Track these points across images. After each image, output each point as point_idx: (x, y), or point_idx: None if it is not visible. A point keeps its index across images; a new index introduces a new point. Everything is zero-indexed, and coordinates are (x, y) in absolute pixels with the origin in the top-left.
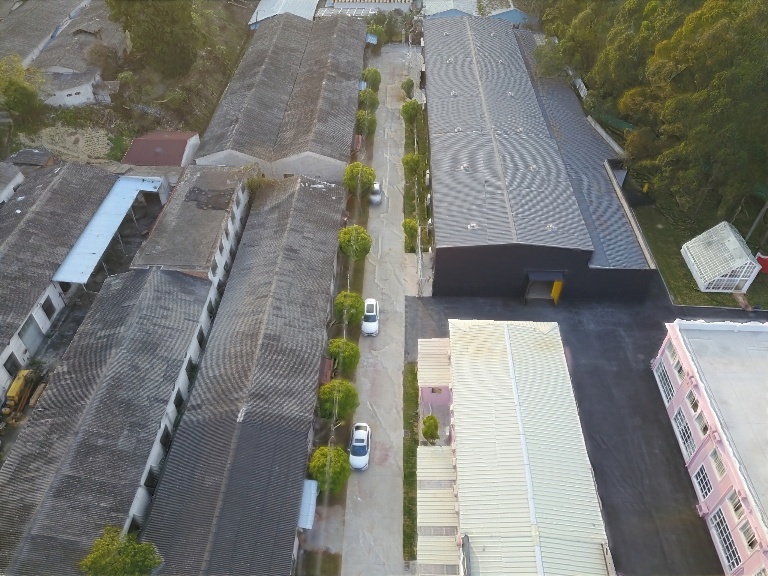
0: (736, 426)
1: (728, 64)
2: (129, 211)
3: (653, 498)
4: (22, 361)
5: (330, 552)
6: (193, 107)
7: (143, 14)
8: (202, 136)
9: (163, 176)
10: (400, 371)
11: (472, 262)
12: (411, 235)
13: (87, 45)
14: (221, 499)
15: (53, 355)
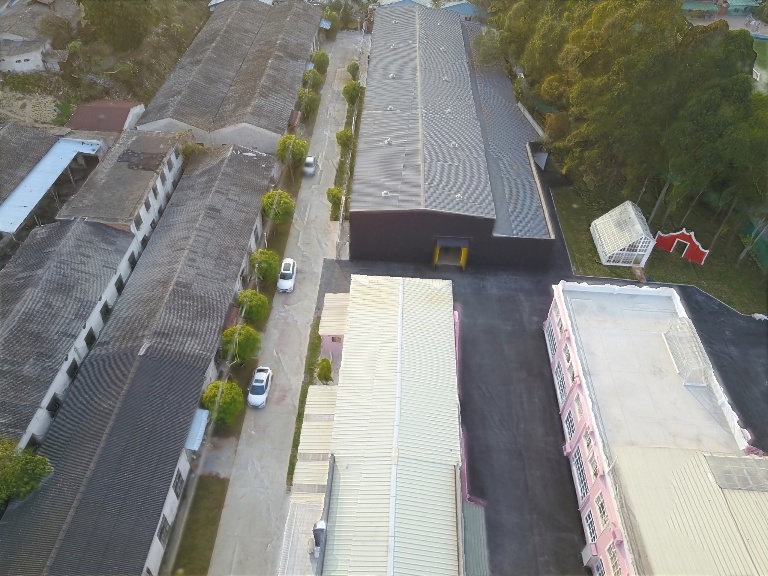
0: (598, 373)
1: (628, 51)
2: (66, 171)
3: (525, 439)
4: None
5: (219, 476)
6: (143, 80)
7: None
8: None
9: (102, 140)
10: (309, 324)
11: (384, 227)
12: (334, 203)
13: (40, 15)
14: (113, 419)
15: None
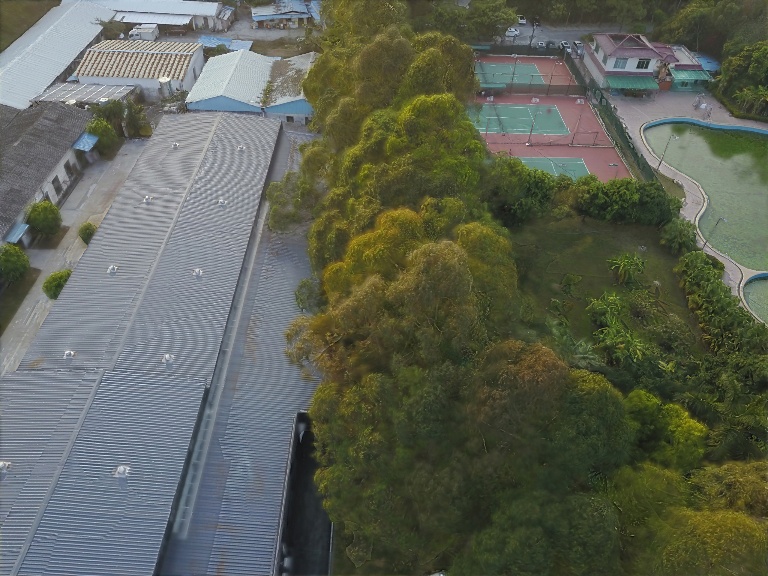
0: None
1: None
2: None
3: None
4: None
5: None
6: None
7: None
8: None
9: None
10: None
11: None
12: None
13: None
14: None
15: None
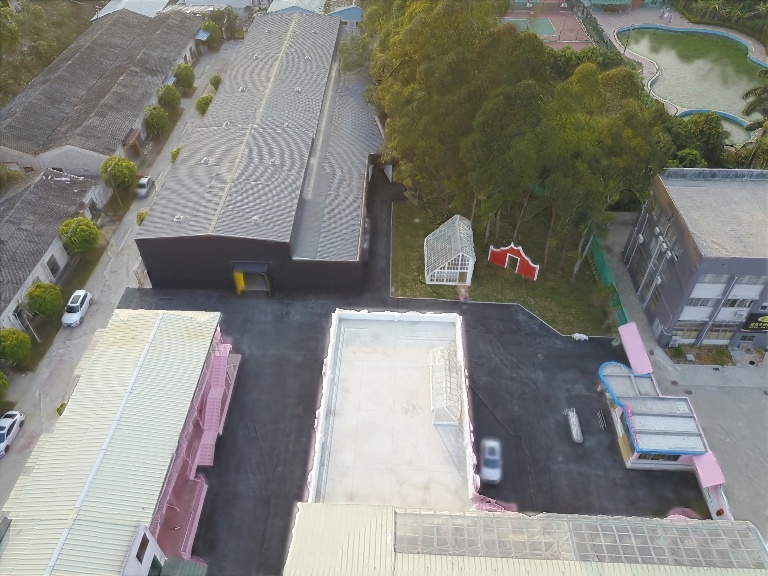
0: (344, 413)
1: None
2: None
3: (278, 484)
4: None
5: None
6: None
7: None
8: None
9: None
10: None
11: (176, 253)
12: None
13: None
14: None
15: None
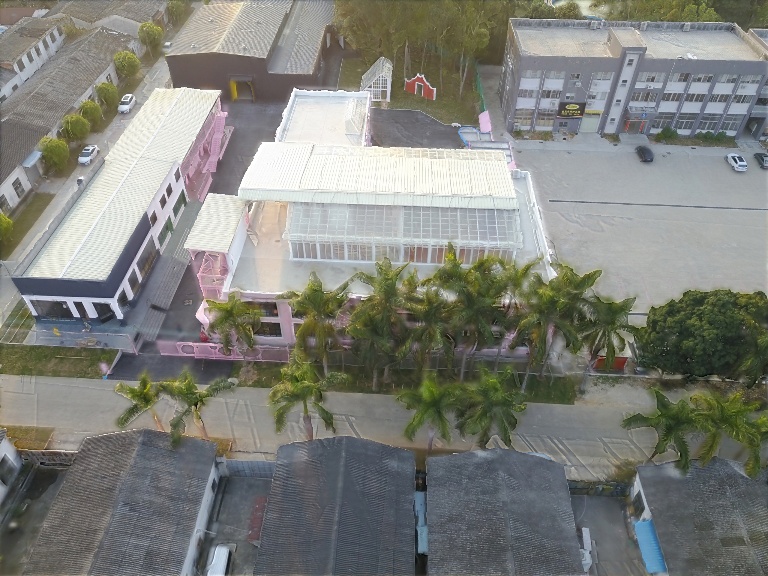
0: (293, 130)
1: None
2: None
3: None
4: None
5: (50, 193)
6: None
7: None
8: None
9: None
10: None
11: (192, 68)
12: None
13: None
14: None
15: None
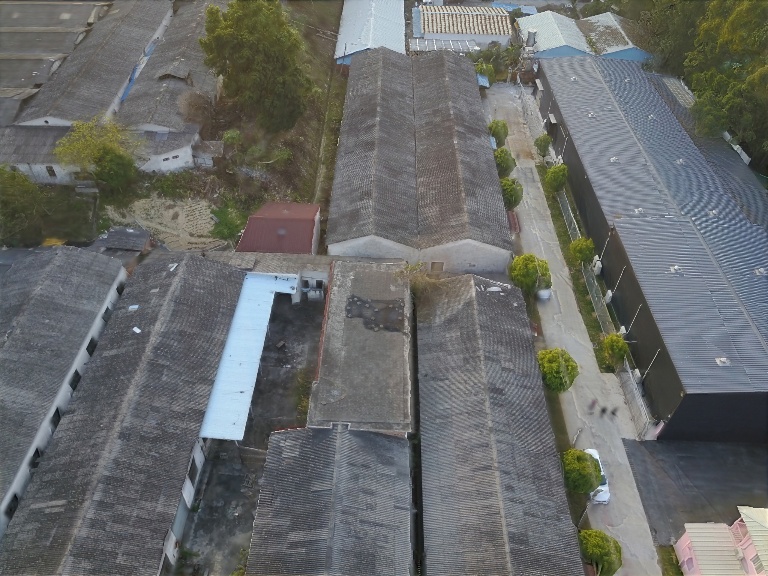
0: None
1: None
2: None
3: None
4: (172, 558)
5: None
6: (299, 167)
7: (253, 61)
8: (311, 202)
9: (299, 272)
10: (654, 560)
11: (724, 408)
12: (619, 357)
13: (179, 94)
14: None
15: (206, 541)
